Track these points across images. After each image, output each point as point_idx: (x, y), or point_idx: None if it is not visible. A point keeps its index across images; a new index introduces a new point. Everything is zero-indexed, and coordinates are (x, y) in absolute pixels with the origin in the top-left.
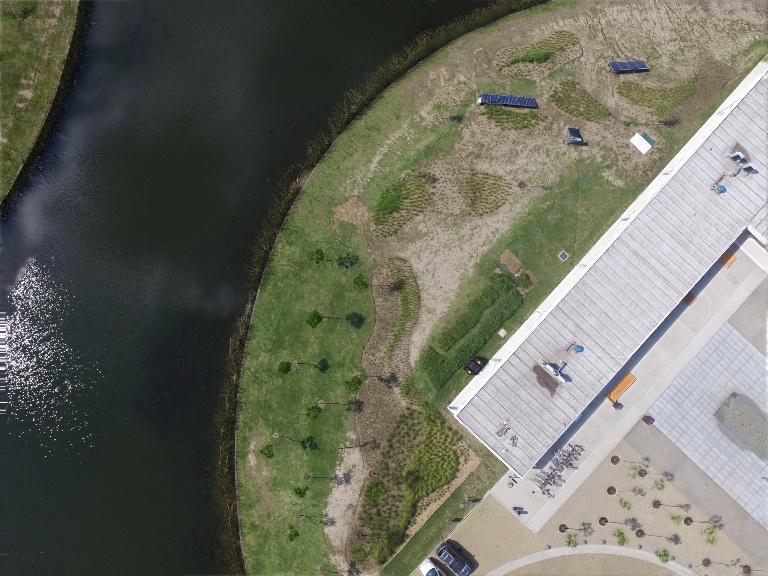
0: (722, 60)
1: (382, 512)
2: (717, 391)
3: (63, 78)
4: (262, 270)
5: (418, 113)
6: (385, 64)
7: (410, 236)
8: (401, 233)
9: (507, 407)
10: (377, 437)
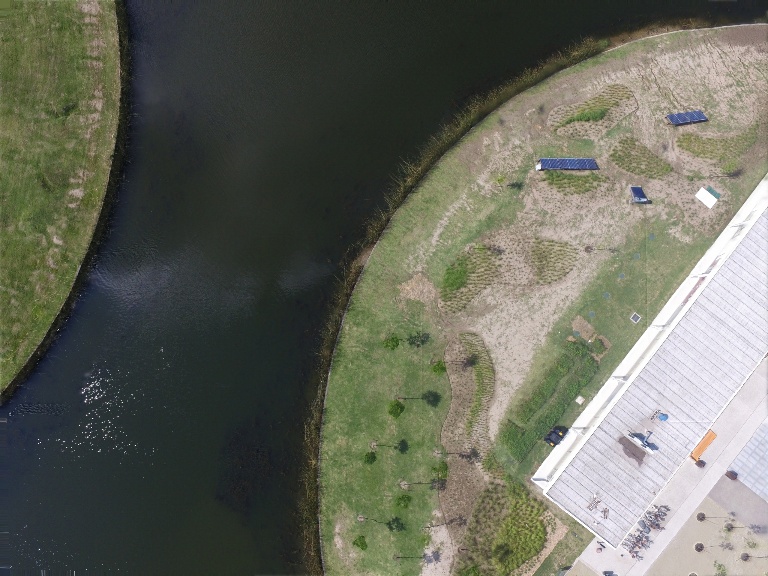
0: None
1: None
2: None
3: (112, 174)
4: (331, 353)
5: (475, 182)
6: (437, 133)
7: (479, 310)
8: (470, 308)
9: (596, 480)
10: (463, 513)
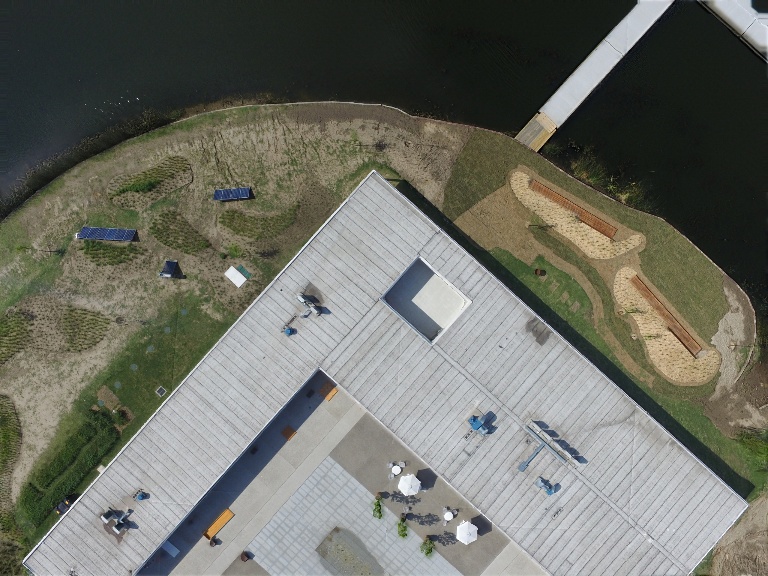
0: (327, 185)
1: None
2: (319, 526)
3: None
4: None
5: (30, 245)
6: (3, 194)
7: (13, 372)
8: (4, 370)
9: (74, 554)
10: None
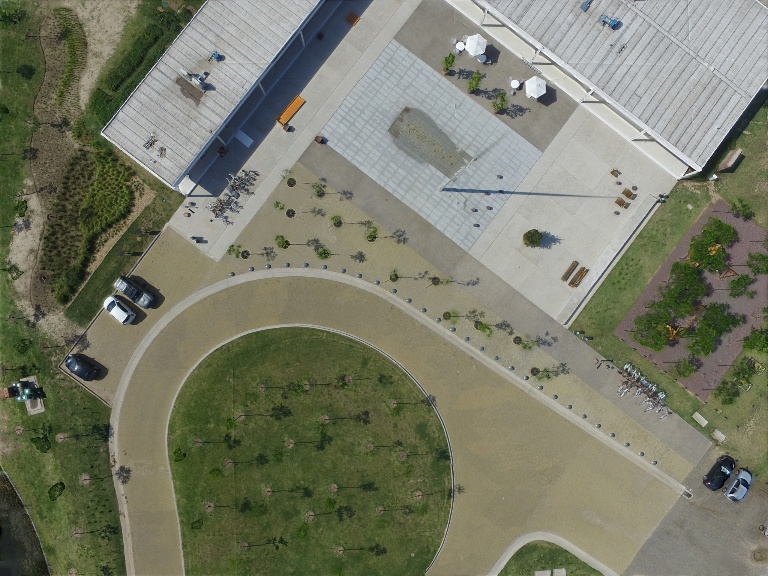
0: None
1: (62, 253)
2: (389, 107)
3: None
4: None
5: None
6: None
7: None
8: None
9: (153, 120)
10: (53, 181)
